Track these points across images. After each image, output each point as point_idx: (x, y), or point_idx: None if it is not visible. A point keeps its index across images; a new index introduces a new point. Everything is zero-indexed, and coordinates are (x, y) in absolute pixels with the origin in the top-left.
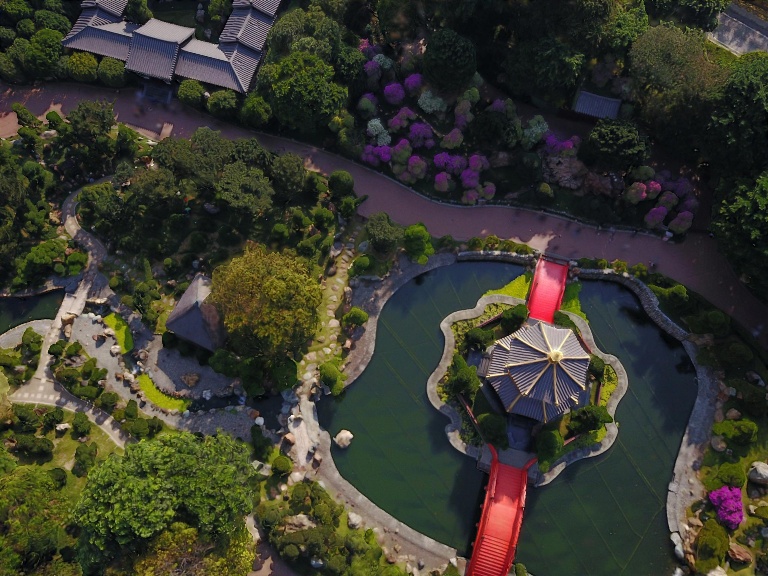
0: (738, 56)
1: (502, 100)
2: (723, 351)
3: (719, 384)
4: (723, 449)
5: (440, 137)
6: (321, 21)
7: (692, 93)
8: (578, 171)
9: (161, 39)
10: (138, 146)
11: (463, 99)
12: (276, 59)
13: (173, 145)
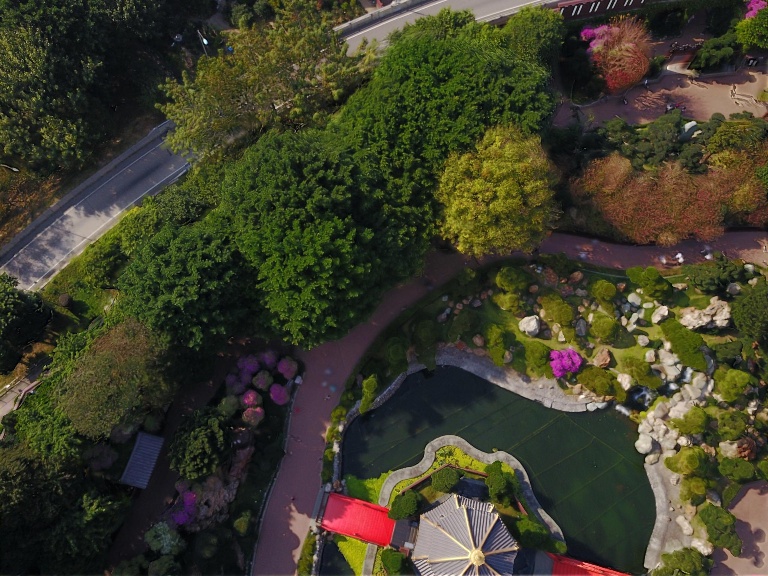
0: (69, 263)
1: (104, 573)
2: (424, 345)
3: (449, 347)
4: (511, 354)
5: None
6: None
7: (152, 361)
8: (219, 480)
9: None
10: None
11: None
12: None
13: None
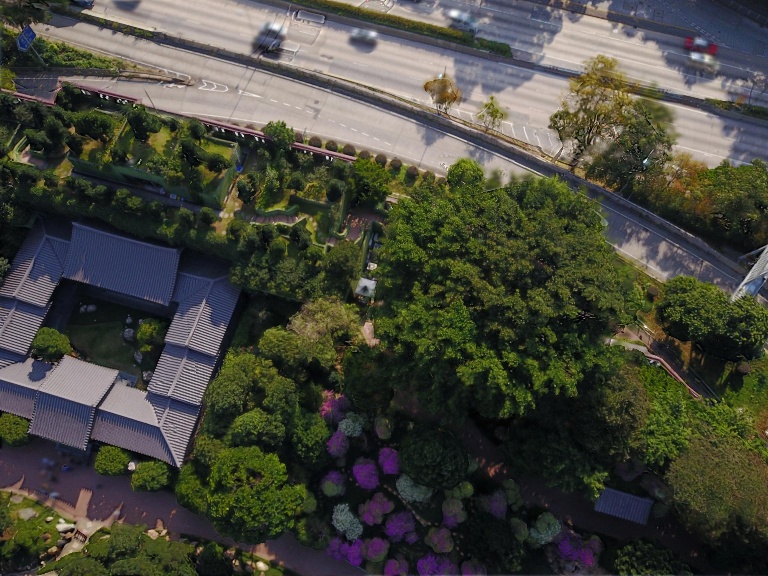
0: None
1: (501, 462)
2: None
3: None
4: None
5: (424, 526)
6: (273, 380)
7: (748, 524)
8: None
9: (72, 400)
10: (44, 539)
11: (452, 497)
12: (216, 431)
13: (80, 575)
